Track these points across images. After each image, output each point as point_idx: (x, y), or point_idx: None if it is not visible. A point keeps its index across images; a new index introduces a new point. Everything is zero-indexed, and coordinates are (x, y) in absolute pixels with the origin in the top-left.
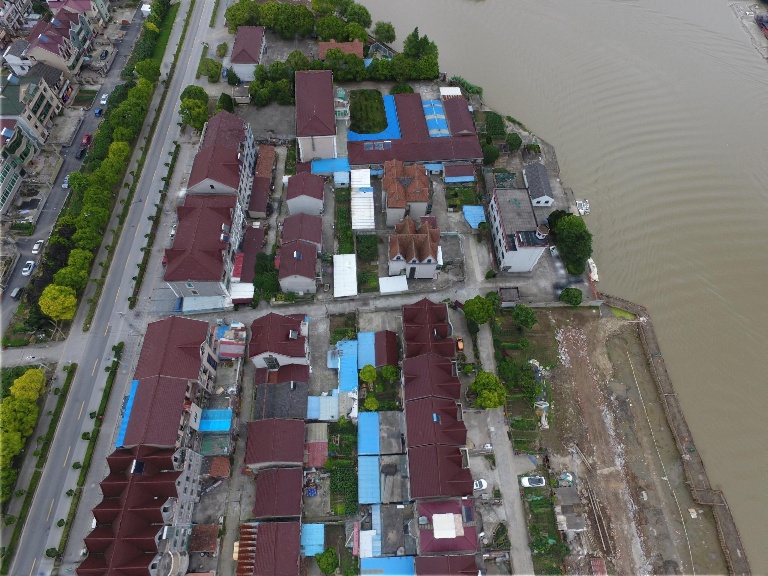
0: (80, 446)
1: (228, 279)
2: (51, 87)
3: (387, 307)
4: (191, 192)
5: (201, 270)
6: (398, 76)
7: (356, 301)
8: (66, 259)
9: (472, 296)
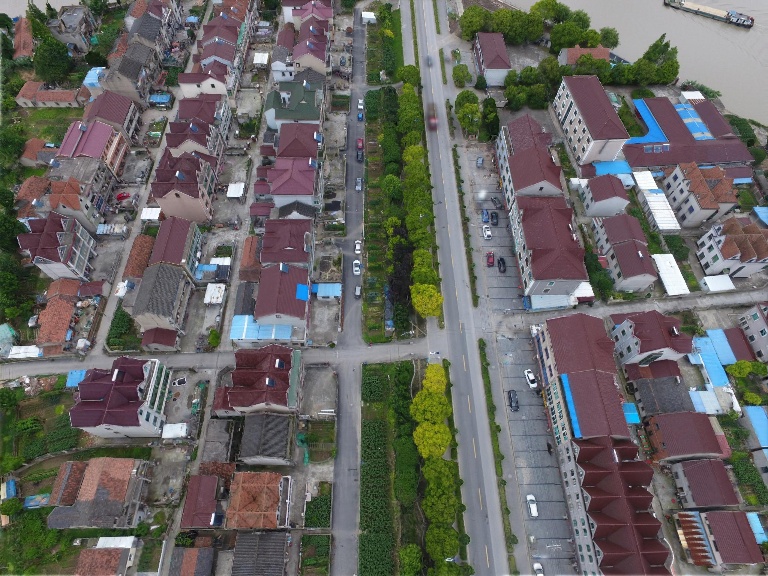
0: (483, 438)
1: None
2: (323, 92)
3: (720, 305)
4: (519, 194)
5: (571, 269)
6: (643, 81)
7: (684, 299)
8: (412, 259)
9: None
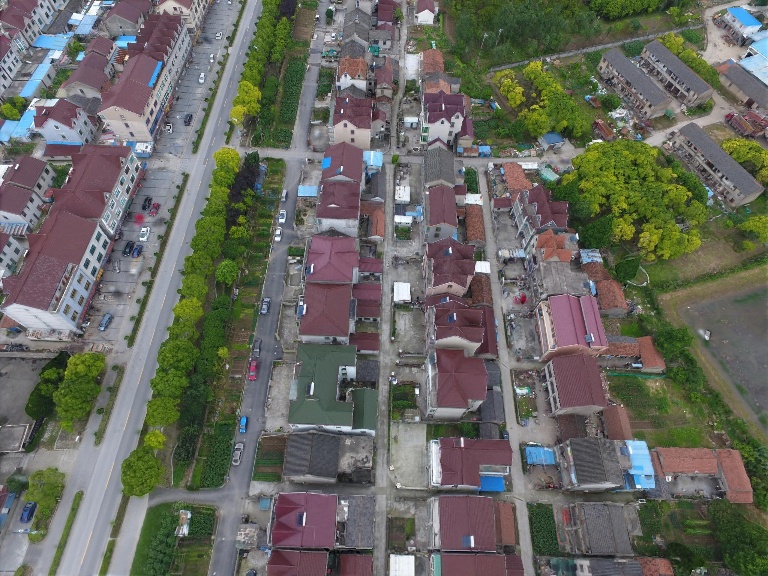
0: (218, 106)
1: None
2: None
3: None
4: None
5: None
6: None
7: None
8: None
9: None
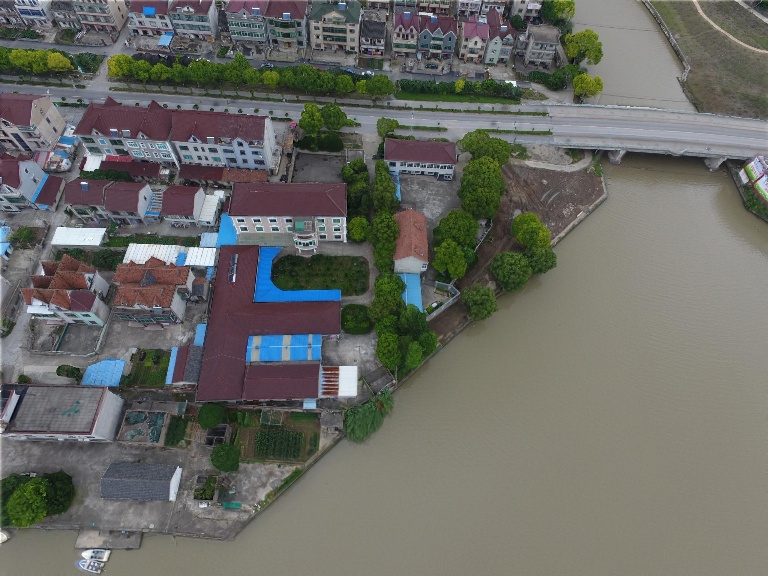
0: None
1: (100, 150)
2: (361, 36)
3: None
4: None
5: None
6: None
7: None
8: None
9: (8, 356)
